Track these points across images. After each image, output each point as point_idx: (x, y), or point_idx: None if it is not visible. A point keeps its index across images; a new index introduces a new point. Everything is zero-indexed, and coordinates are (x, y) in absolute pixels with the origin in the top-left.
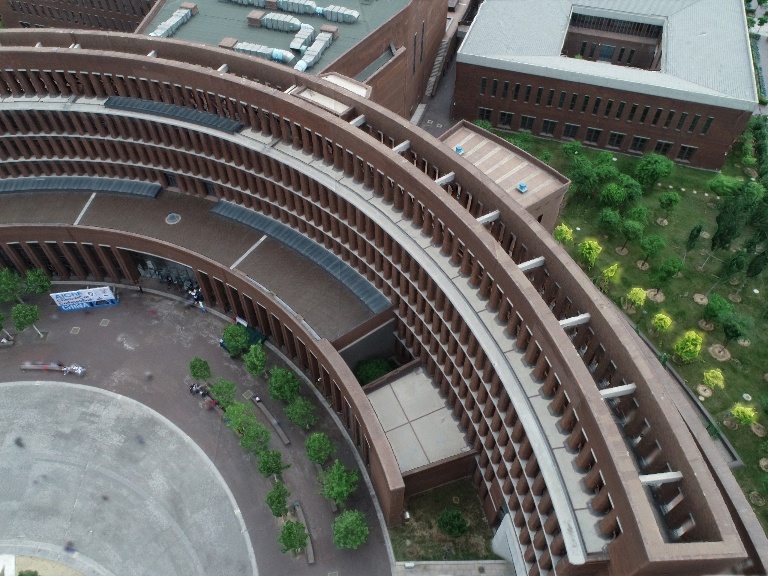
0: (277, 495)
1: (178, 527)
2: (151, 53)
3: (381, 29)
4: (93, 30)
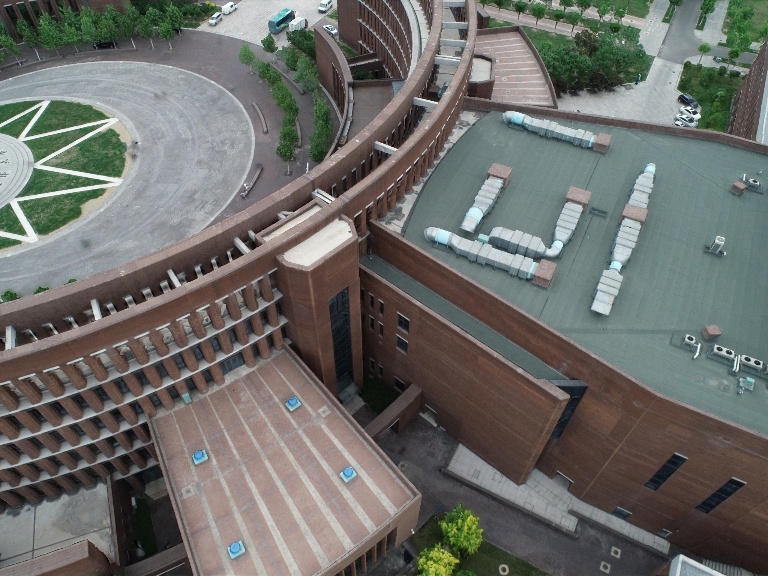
0: (39, 289)
1: (88, 257)
2: (437, 103)
3: (565, 342)
4: (469, 59)
